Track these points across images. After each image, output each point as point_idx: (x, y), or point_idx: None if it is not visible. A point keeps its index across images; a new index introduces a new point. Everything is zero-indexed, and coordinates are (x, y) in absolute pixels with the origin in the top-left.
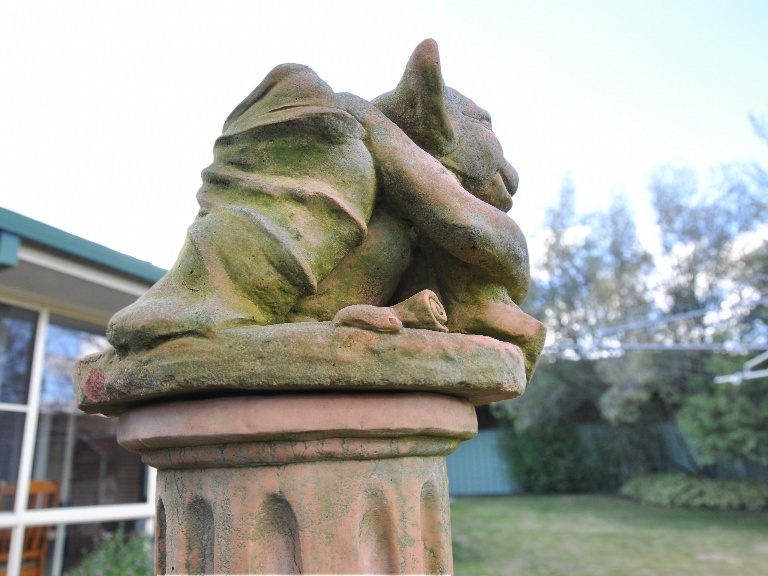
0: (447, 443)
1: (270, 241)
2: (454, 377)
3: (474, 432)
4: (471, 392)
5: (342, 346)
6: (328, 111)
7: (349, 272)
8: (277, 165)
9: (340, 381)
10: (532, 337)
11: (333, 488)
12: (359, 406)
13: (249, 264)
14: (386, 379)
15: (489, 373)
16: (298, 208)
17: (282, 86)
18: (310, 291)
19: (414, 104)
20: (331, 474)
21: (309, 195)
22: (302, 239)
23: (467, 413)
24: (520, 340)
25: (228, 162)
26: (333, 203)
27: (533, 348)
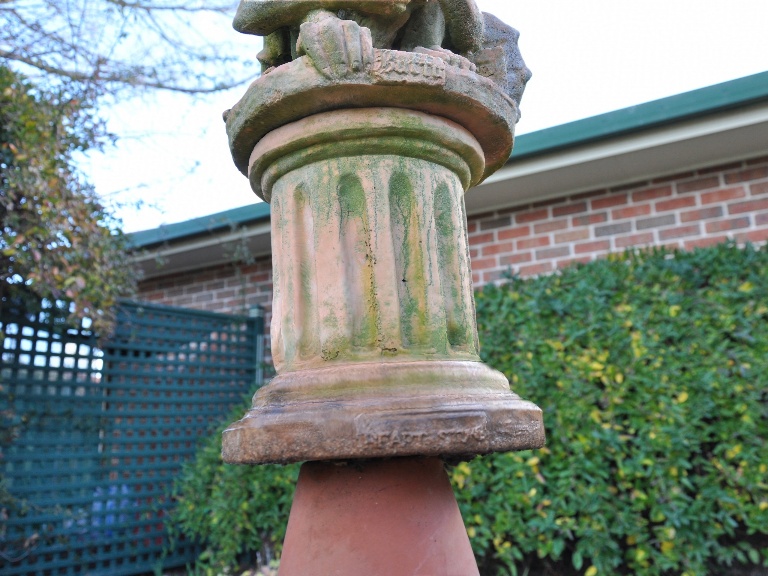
0: (303, 153)
1: None
2: None
3: (318, 134)
4: (288, 114)
5: None
6: None
7: None
8: None
9: None
10: None
11: None
12: None
13: None
14: None
15: None
16: None
17: None
18: None
19: None
20: None
21: None
22: None
23: None
24: (303, 50)
25: None
26: None
27: None
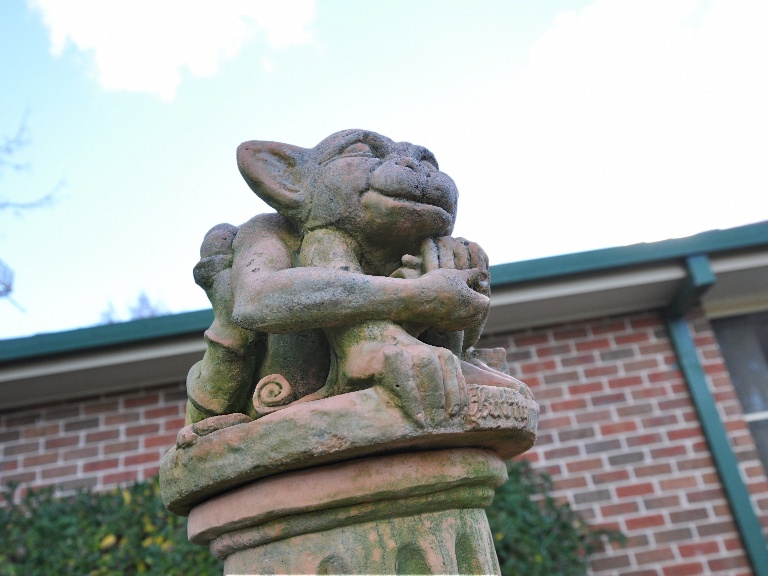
0: (340, 513)
1: None
2: (244, 465)
3: (377, 493)
4: None
5: None
6: None
7: (271, 372)
8: None
9: (182, 494)
10: (382, 372)
11: (242, 574)
12: (215, 506)
13: None
14: (198, 485)
15: (284, 447)
16: None
17: None
18: (215, 413)
19: None
20: (241, 562)
21: None
22: None
23: (343, 479)
24: (376, 380)
25: None
26: None
27: (390, 383)
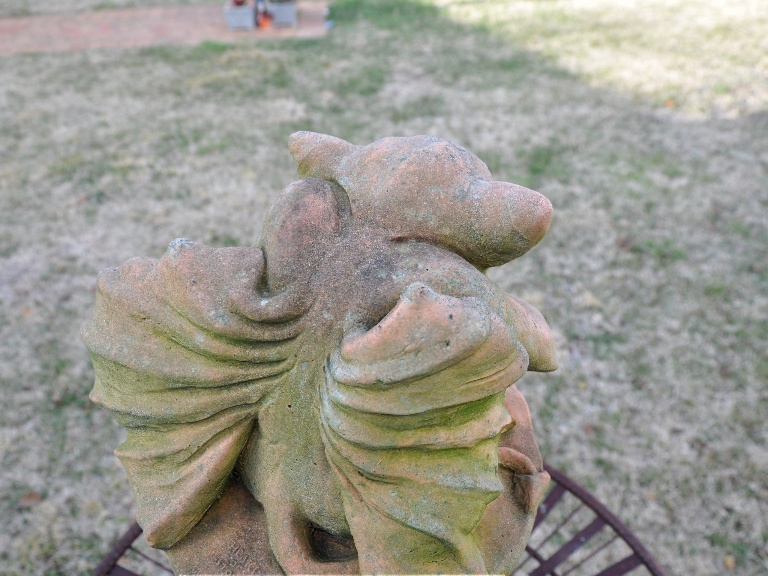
0: None
1: None
2: None
3: None
4: None
5: None
6: None
7: None
8: None
9: None
10: None
11: None
12: None
13: None
14: None
15: None
16: None
17: None
18: None
19: None
20: None
21: None
22: None
23: None
24: None
25: None
26: None
27: None
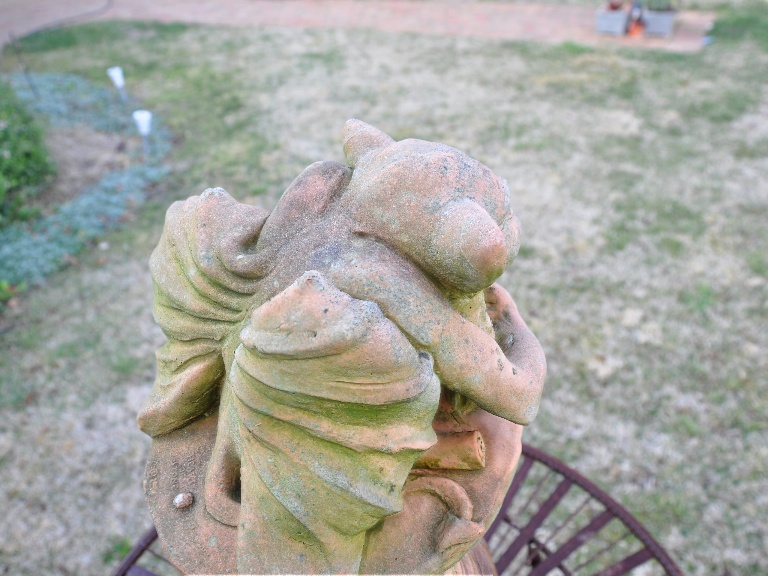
0: None
1: (374, 509)
2: None
3: None
4: None
5: (447, 561)
6: (415, 394)
7: None
8: (350, 418)
9: None
10: None
11: None
12: None
13: (357, 525)
14: None
15: None
16: (384, 459)
17: (350, 360)
18: None
19: (465, 279)
20: None
21: (396, 452)
22: (396, 488)
23: None
24: None
25: (281, 403)
26: (418, 450)
27: None
